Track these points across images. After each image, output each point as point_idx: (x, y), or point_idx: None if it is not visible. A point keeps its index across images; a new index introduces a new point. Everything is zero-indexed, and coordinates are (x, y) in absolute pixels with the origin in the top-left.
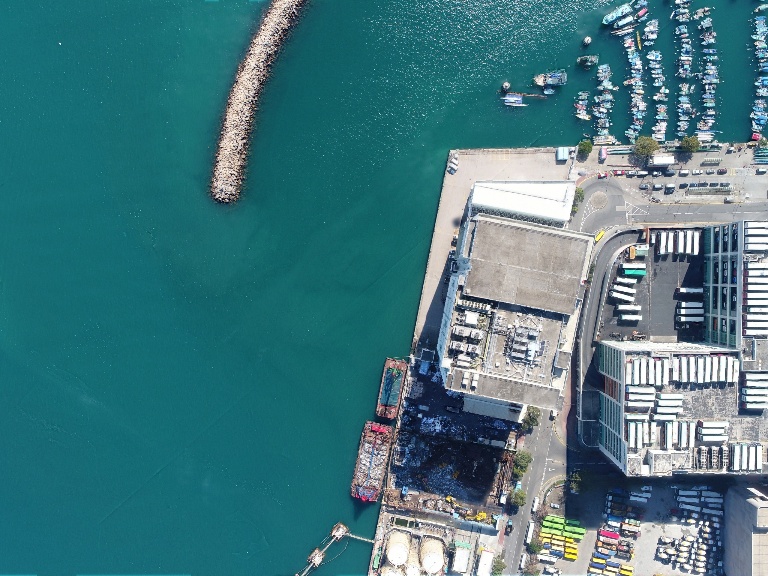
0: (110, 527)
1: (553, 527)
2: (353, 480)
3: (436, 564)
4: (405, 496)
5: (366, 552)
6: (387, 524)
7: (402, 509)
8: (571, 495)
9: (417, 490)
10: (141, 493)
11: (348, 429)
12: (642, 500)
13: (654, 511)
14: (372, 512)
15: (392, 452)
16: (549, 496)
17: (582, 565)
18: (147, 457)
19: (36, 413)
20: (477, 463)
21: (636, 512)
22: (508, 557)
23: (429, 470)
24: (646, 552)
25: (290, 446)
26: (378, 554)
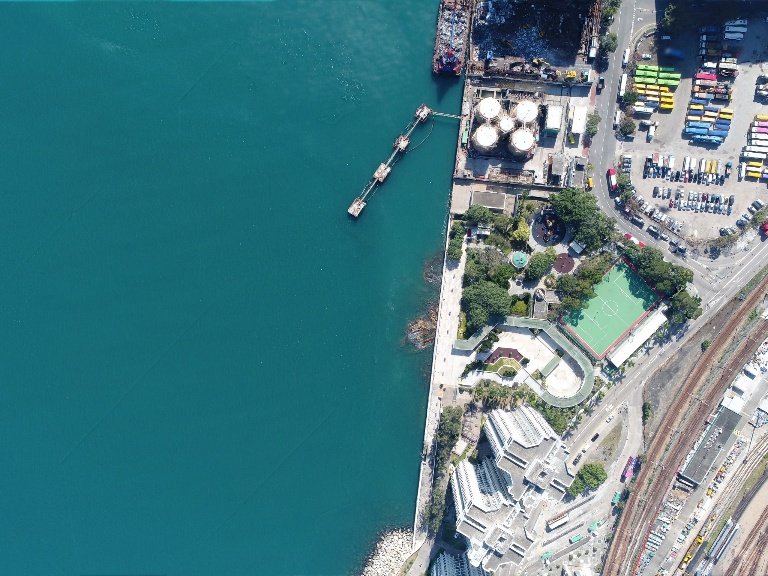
0: (190, 104)
1: (647, 75)
2: (434, 56)
3: (530, 112)
4: (490, 62)
5: (452, 133)
6: (473, 97)
7: (488, 77)
8: (662, 43)
9: (502, 56)
10: (219, 65)
11: (425, 6)
12: (738, 36)
13: (750, 50)
14: (456, 91)
15: (473, 22)
16: (640, 47)
17: (679, 116)
18: (222, 26)
19: (98, 32)
20: (563, 17)
21: (732, 51)
22: (601, 117)
23: (513, 33)
24: (745, 94)
25: (369, 8)
26: (466, 129)
